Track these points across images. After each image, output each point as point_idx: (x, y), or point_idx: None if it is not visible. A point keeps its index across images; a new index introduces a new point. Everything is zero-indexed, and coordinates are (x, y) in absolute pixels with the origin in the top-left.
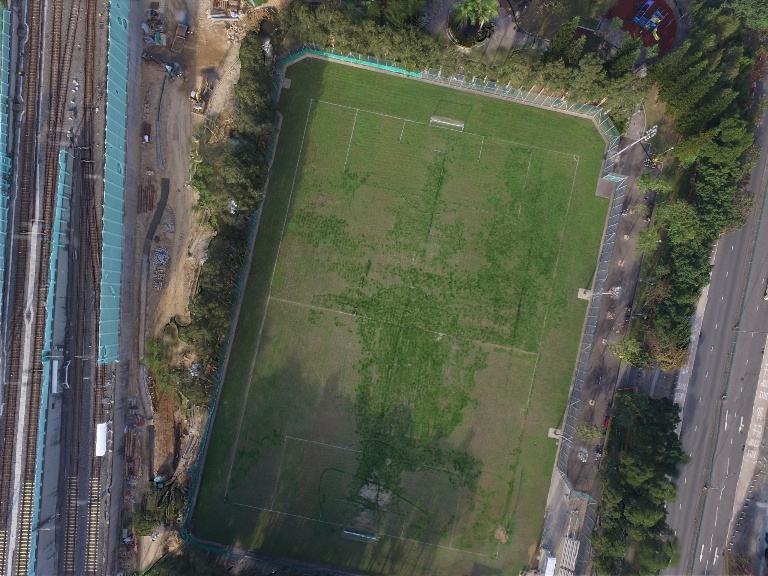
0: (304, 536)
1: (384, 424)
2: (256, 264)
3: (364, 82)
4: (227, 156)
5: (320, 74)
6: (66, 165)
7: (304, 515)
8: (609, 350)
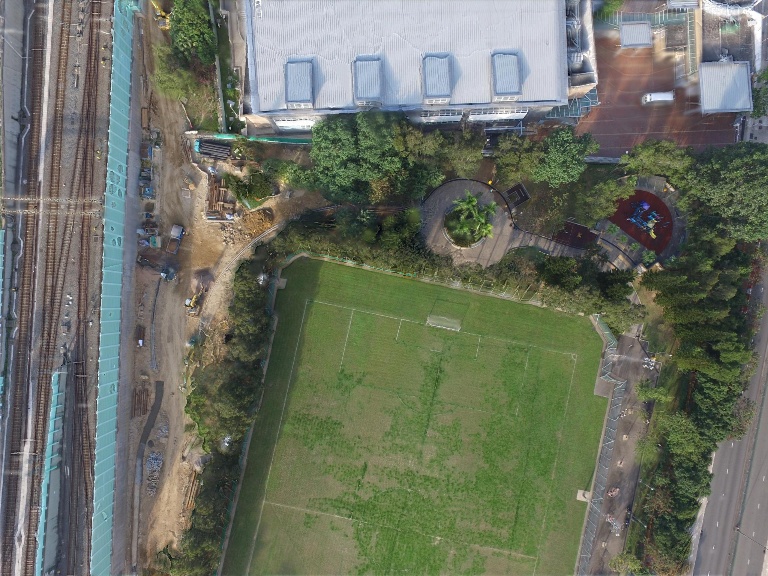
0: None
1: None
2: (251, 467)
3: (360, 282)
4: (221, 387)
5: (316, 274)
6: (59, 386)
7: None
8: (609, 566)
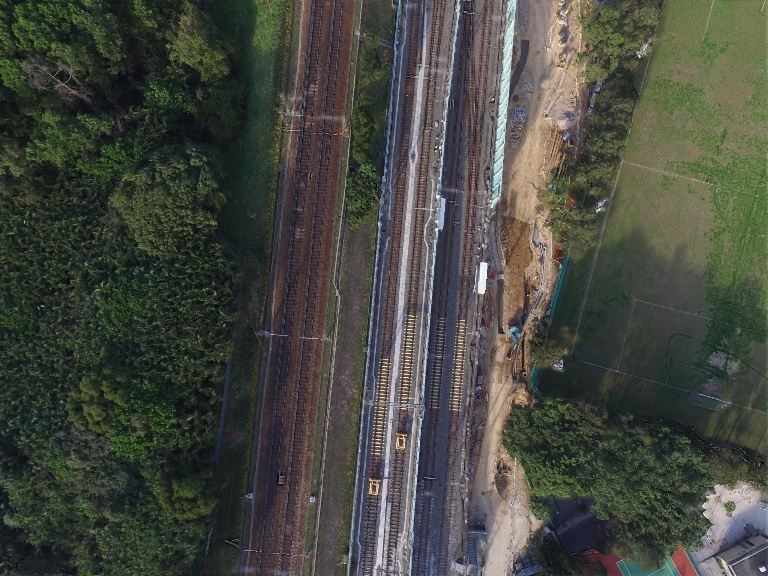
0: (650, 399)
1: (735, 293)
2: None
3: None
4: None
5: None
6: None
7: (650, 378)
8: None
